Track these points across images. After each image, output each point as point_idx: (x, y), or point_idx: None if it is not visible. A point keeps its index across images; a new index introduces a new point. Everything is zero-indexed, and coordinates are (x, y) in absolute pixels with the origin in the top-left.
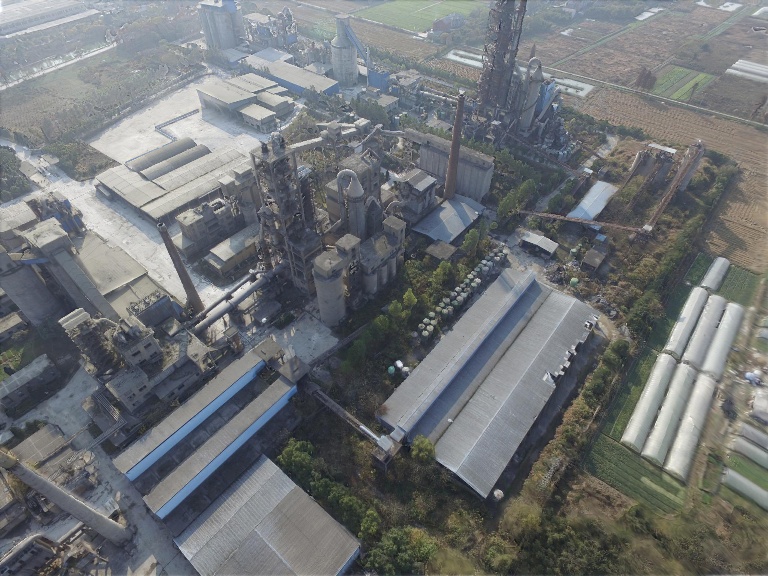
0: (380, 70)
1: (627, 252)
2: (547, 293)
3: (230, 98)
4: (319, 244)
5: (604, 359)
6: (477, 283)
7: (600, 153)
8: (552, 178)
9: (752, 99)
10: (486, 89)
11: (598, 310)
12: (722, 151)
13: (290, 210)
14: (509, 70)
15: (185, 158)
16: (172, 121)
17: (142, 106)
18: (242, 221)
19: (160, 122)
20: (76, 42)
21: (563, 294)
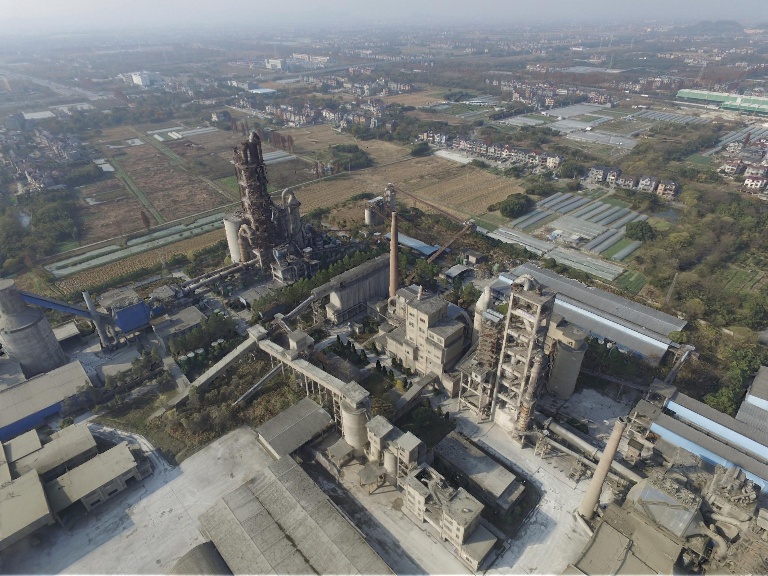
0: (129, 302)
1: None
2: None
3: (18, 514)
4: None
5: (562, 270)
6: None
7: None
8: None
9: (289, 172)
10: None
11: (515, 267)
12: (348, 196)
13: None
14: None
15: None
16: None
17: None
18: None
19: None
20: None
21: (515, 270)
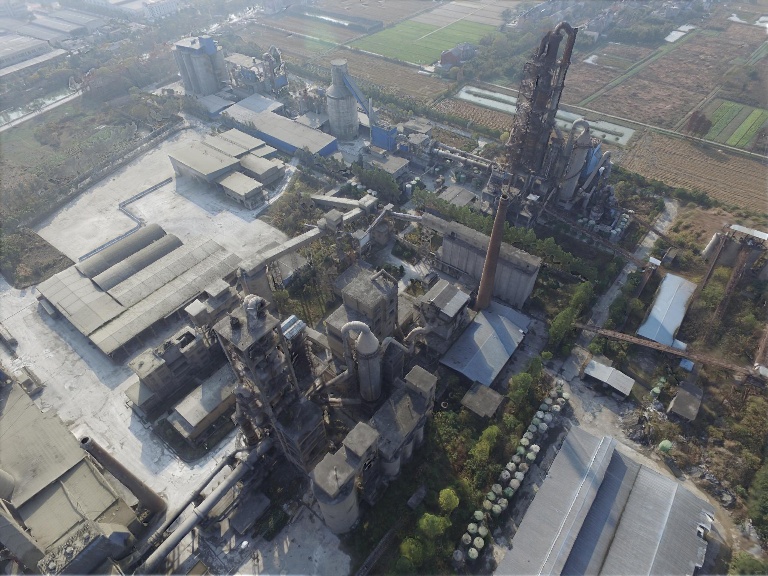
0: (385, 125)
1: (730, 395)
2: (634, 471)
3: (208, 166)
4: (319, 420)
5: None
6: (535, 453)
7: (659, 226)
8: (609, 271)
9: None
10: (518, 154)
11: (704, 491)
12: None
13: (277, 386)
14: (547, 132)
15: (150, 255)
16: (139, 195)
17: (105, 175)
18: (220, 348)
19: (125, 197)
20: (37, 90)
21: (657, 474)
